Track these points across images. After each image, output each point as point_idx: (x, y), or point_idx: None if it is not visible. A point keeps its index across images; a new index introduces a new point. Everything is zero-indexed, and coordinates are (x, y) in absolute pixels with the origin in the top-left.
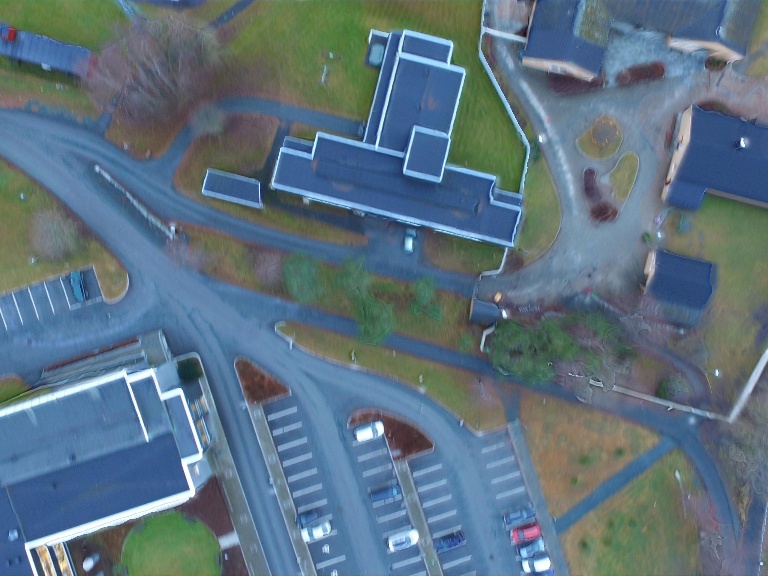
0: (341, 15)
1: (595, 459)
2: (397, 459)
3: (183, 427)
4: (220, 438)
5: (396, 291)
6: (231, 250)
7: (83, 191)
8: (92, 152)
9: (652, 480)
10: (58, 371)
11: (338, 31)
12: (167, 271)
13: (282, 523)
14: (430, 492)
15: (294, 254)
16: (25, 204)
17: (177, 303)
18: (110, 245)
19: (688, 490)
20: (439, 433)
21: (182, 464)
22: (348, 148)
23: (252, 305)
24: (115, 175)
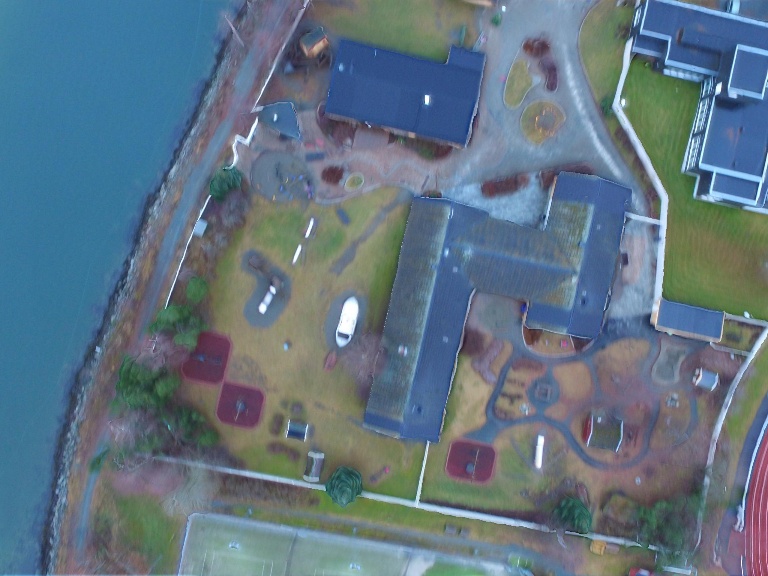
0: None
1: None
2: None
3: None
4: None
5: None
6: None
7: None
8: None
9: None
10: None
11: None
12: None
13: None
14: None
15: None
16: None
17: None
18: None
19: None
20: None
21: None
22: None
23: None
24: None
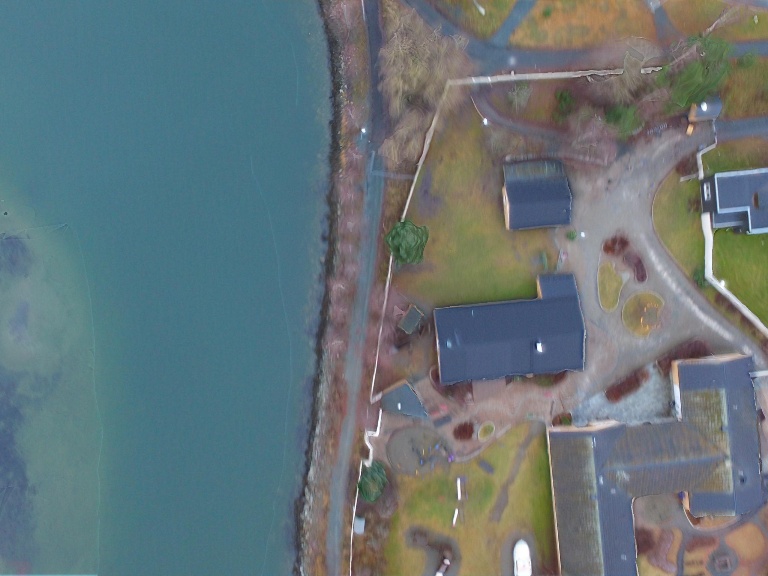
0: None
1: None
2: None
3: None
4: None
5: None
6: None
7: None
8: None
9: None
10: None
11: None
12: None
13: None
14: None
15: None
16: None
17: None
18: None
19: None
20: None
21: None
22: None
23: None
24: None
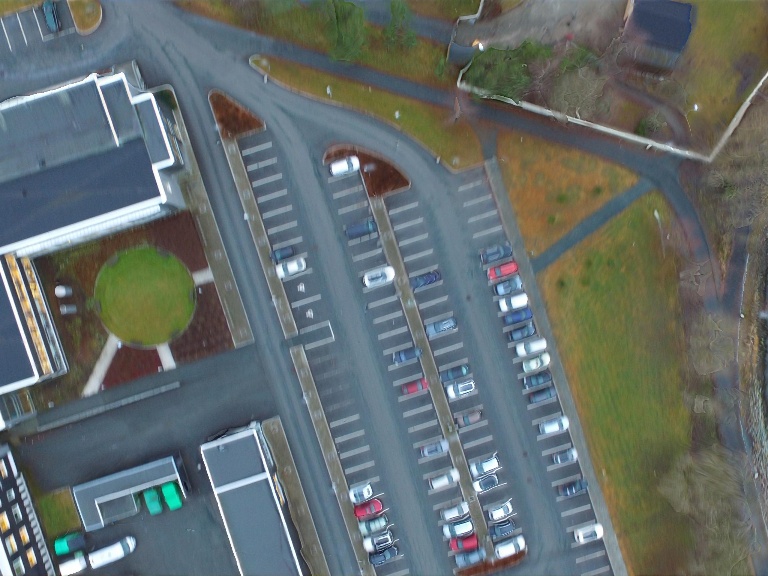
0: None
1: (573, 198)
2: (373, 193)
3: (154, 133)
4: (194, 172)
5: (373, 34)
6: None
7: None
8: None
9: (631, 219)
10: None
11: None
12: (141, 3)
13: (257, 260)
14: (406, 230)
15: None
16: None
17: (151, 36)
18: None
19: (667, 230)
20: (415, 171)
21: (153, 169)
22: None
23: (226, 38)
24: None
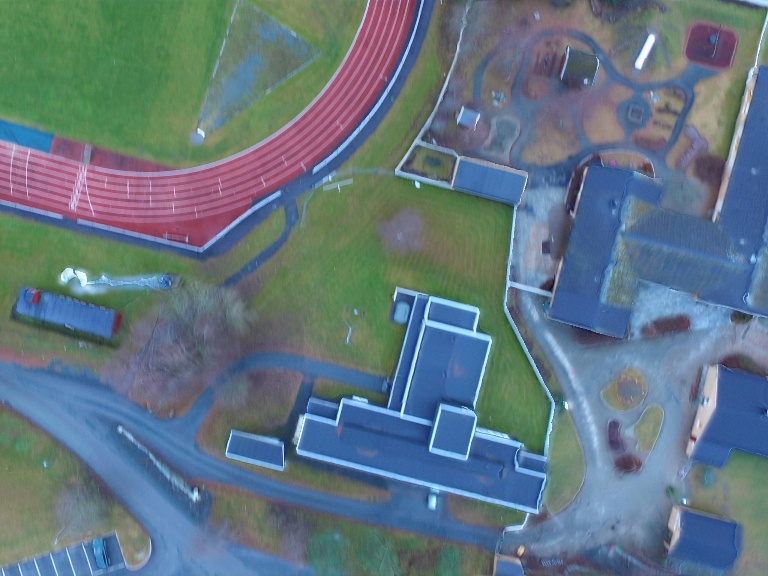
0: (366, 269)
1: None
2: None
3: None
4: None
5: (419, 547)
6: (254, 509)
7: (106, 453)
8: (115, 412)
9: None
10: None
11: (363, 286)
12: (190, 536)
13: None
14: None
15: (317, 512)
16: (48, 470)
17: (200, 569)
18: (133, 509)
19: None
20: None
21: None
22: (373, 414)
23: (275, 571)
24: (138, 435)
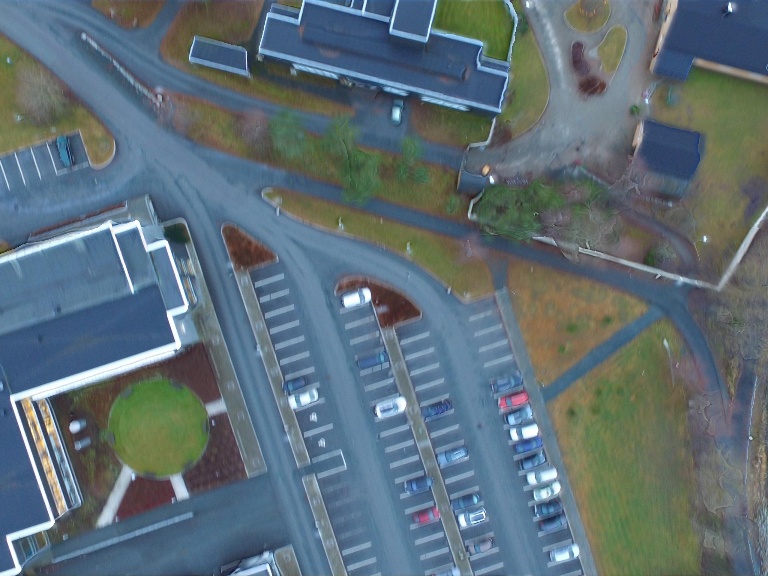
0: None
1: (583, 327)
2: (384, 325)
3: (168, 279)
4: (207, 304)
5: (384, 162)
6: (218, 119)
7: (70, 58)
8: (79, 20)
9: (640, 348)
10: (44, 235)
11: None
12: (154, 137)
13: (269, 390)
14: (418, 360)
15: (281, 124)
16: (11, 69)
17: (164, 169)
18: (97, 111)
19: (676, 358)
20: (426, 301)
21: (167, 316)
22: (335, 13)
23: (239, 171)
24: (102, 43)
